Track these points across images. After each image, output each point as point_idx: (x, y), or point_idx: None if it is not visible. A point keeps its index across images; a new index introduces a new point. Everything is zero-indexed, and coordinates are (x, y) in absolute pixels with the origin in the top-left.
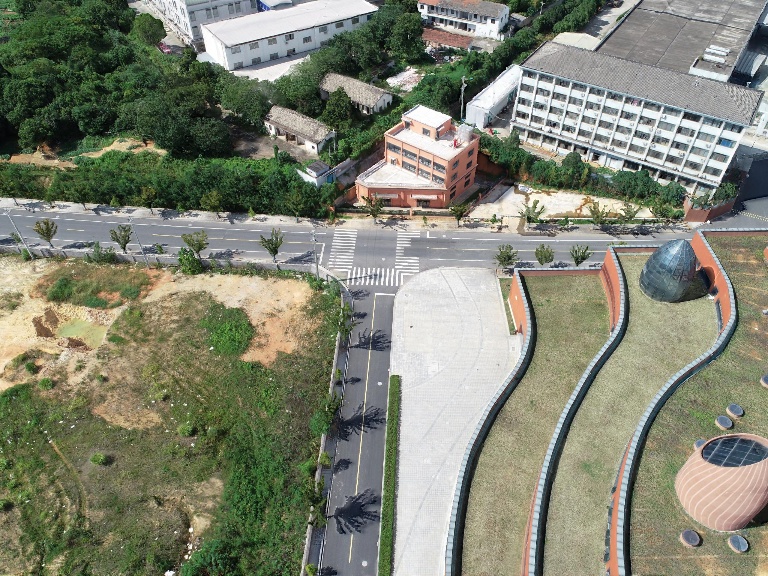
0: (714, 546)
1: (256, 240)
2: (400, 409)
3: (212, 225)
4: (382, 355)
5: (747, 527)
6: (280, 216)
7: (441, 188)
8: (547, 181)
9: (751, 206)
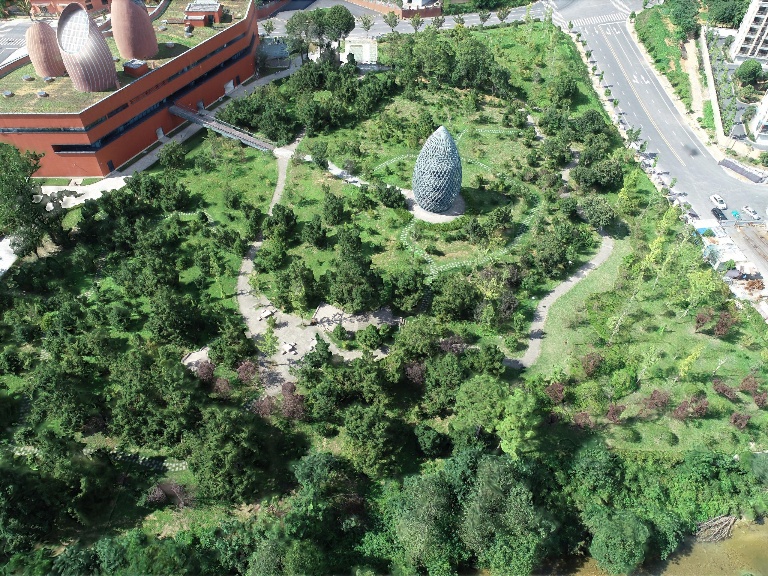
0: (37, 81)
1: None
2: None
3: None
4: None
5: (59, 77)
6: None
7: None
8: (159, 2)
9: (281, 15)
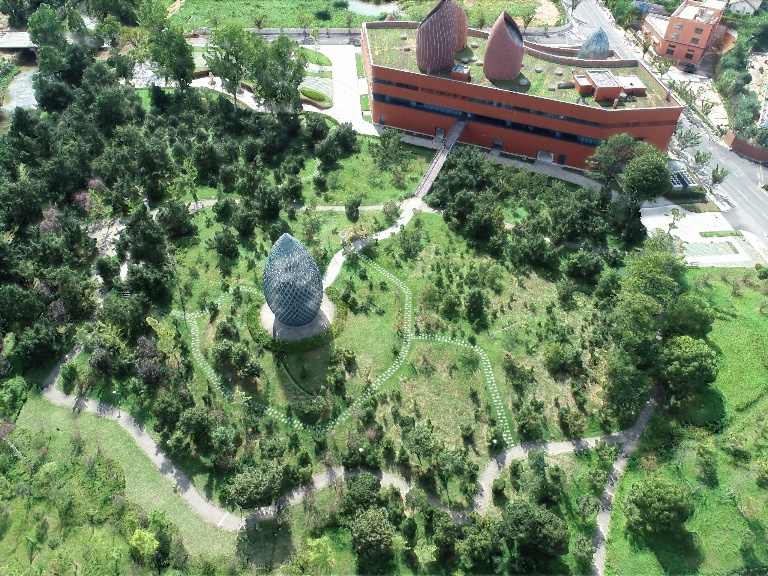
0: None
1: None
2: None
3: (590, 0)
4: None
5: None
6: (611, 14)
7: (663, 37)
8: None
9: None
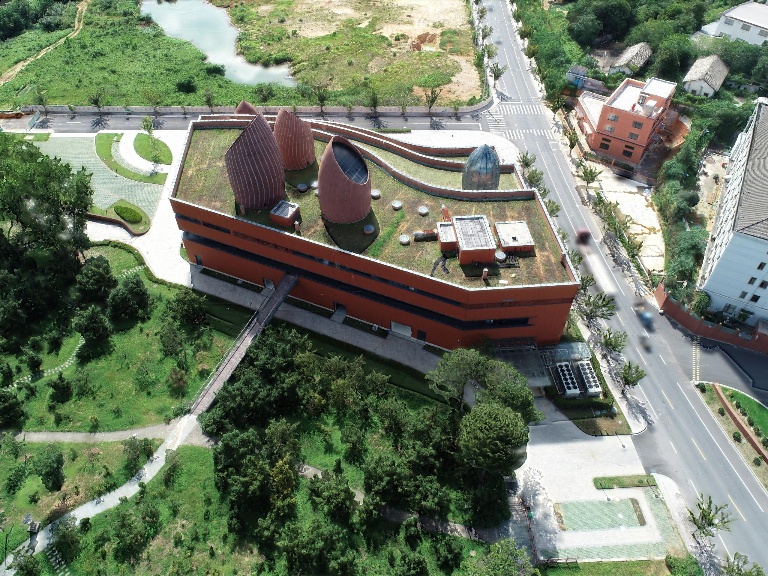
0: None
1: (514, 79)
2: (387, 133)
3: (522, 64)
4: (427, 127)
5: None
6: (543, 84)
7: (595, 128)
8: None
9: (715, 354)
